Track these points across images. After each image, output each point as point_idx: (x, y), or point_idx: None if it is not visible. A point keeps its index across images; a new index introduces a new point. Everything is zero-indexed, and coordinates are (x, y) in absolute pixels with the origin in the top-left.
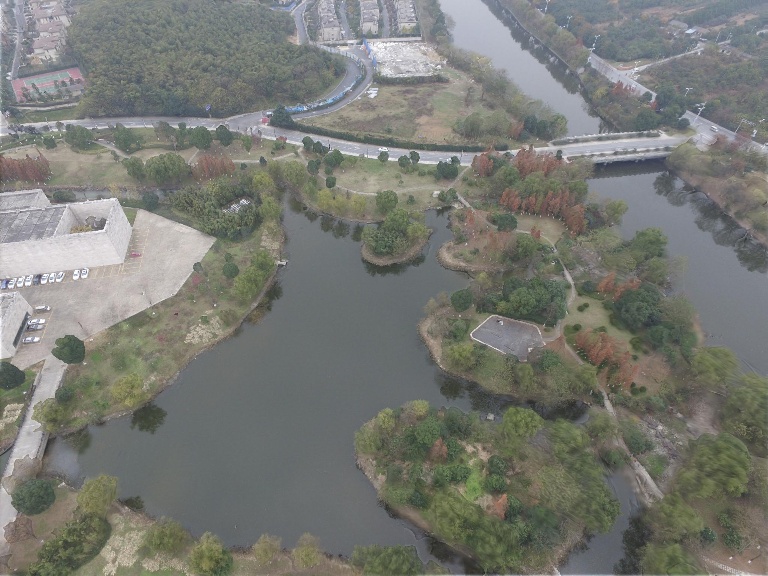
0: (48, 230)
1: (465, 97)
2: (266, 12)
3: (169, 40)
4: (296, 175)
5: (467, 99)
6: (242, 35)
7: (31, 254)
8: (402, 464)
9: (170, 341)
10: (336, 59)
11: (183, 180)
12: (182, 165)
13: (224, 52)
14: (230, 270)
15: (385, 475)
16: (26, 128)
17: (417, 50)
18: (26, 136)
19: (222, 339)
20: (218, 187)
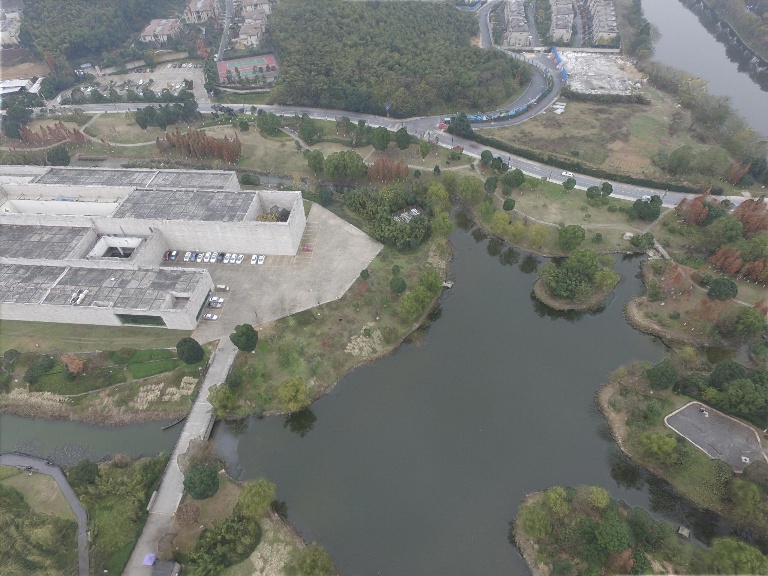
0: (239, 214)
1: (669, 124)
2: (453, 11)
3: (360, 35)
4: (472, 191)
5: (672, 127)
6: (429, 34)
7: (221, 234)
8: (570, 560)
9: (331, 347)
10: (524, 67)
11: (356, 178)
12: (360, 165)
13: (411, 51)
14: (398, 285)
15: (548, 566)
16: (226, 109)
17: (613, 64)
18: (224, 116)
19: (381, 356)
20: (393, 193)
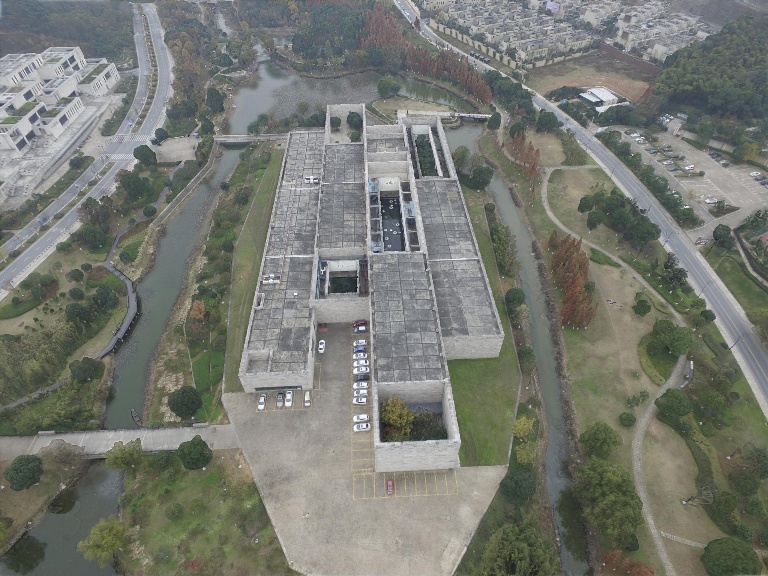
0: (394, 373)
1: None
2: None
3: None
4: None
5: None
6: None
7: None
8: None
9: None
10: None
11: None
12: (610, 532)
13: None
14: None
15: None
16: (674, 271)
17: None
18: None
19: None
20: None
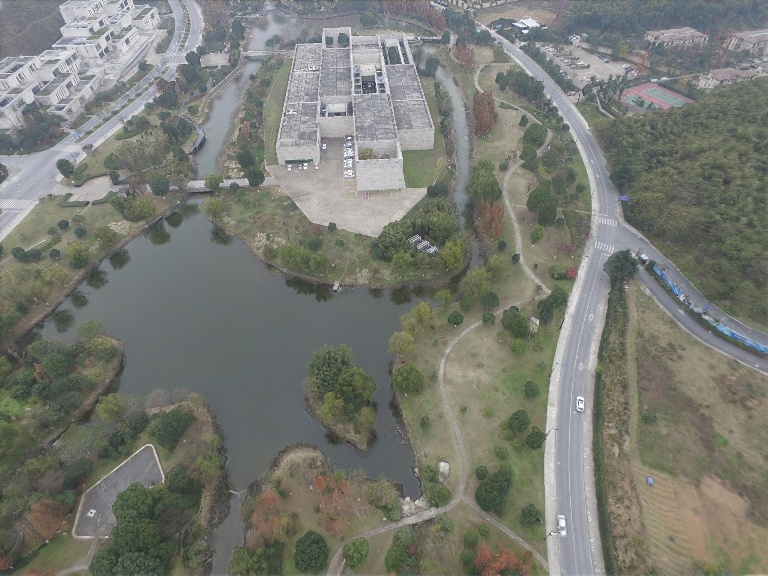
0: (367, 139)
1: None
2: None
3: (766, 132)
4: None
5: None
6: None
7: None
8: None
9: (262, 225)
10: None
11: None
12: (479, 193)
13: None
14: None
15: None
16: (549, 106)
17: None
18: None
19: (255, 254)
20: (436, 220)
